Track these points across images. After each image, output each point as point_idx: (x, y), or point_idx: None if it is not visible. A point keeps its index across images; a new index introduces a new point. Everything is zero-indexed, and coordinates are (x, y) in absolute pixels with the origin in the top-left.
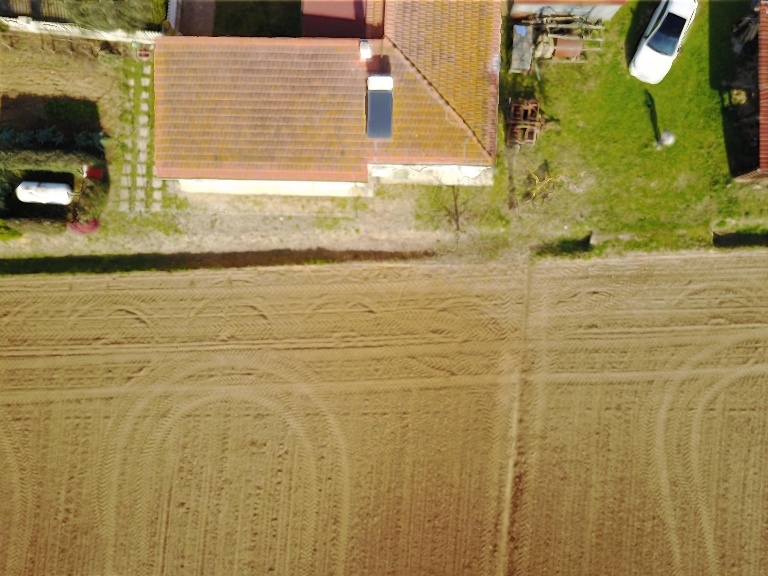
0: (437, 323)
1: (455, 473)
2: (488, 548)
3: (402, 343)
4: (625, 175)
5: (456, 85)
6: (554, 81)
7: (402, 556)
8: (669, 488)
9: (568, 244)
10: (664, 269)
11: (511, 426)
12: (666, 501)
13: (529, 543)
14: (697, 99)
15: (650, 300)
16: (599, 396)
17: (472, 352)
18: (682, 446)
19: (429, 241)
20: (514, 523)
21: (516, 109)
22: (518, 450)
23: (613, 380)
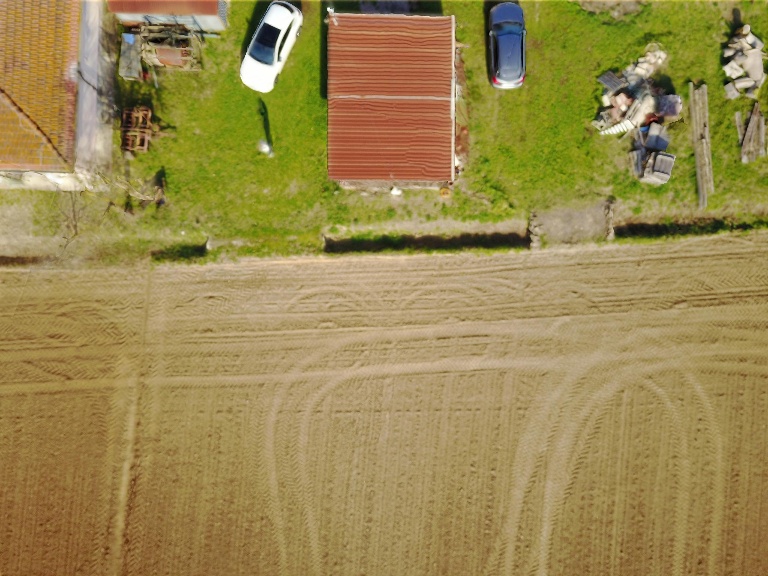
0: (55, 328)
1: (68, 477)
2: (100, 551)
3: (19, 348)
4: (240, 181)
5: (31, 92)
6: (171, 89)
7: (12, 560)
8: (277, 489)
9: (188, 249)
10: (277, 274)
11: (126, 429)
12: (274, 502)
13: (141, 545)
14: (308, 107)
15: (263, 304)
16: (212, 399)
17: (89, 356)
18: (290, 447)
19: (52, 246)
20: (128, 526)
21: (128, 116)
22: (135, 453)
23: (226, 383)
